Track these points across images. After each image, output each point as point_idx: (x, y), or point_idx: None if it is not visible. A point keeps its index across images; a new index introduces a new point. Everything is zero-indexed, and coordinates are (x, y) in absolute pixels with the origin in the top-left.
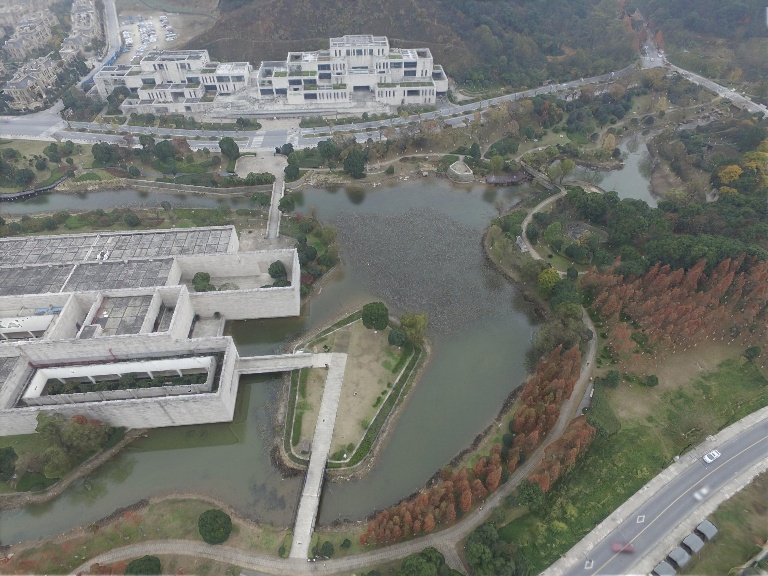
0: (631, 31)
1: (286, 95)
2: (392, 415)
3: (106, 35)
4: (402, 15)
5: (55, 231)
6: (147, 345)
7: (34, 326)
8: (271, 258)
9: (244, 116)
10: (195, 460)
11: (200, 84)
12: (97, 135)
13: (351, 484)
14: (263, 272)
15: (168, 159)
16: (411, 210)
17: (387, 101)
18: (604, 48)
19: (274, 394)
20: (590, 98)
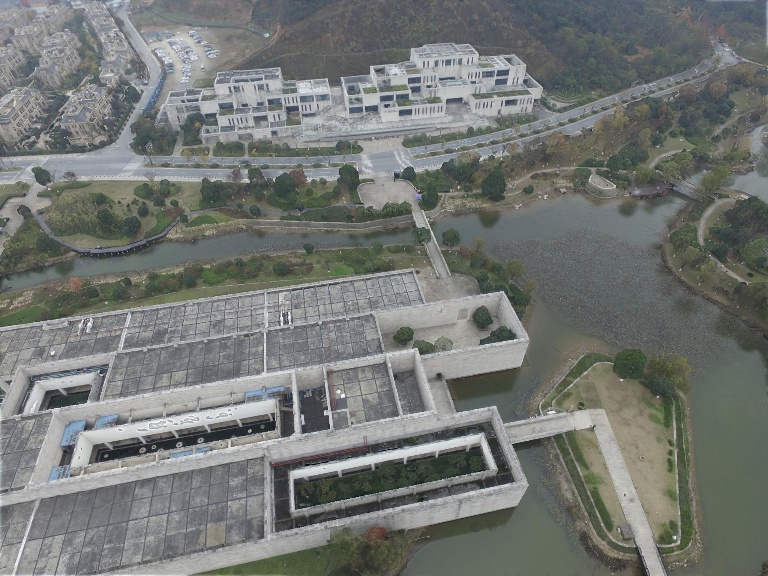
0: (695, 26)
1: (376, 112)
2: (689, 478)
3: (139, 55)
4: (476, 20)
5: (196, 288)
6: (406, 427)
7: (246, 413)
8: (475, 304)
9: (339, 138)
10: (484, 557)
11: (282, 106)
12: (184, 170)
13: (690, 570)
14: (457, 319)
15: (290, 194)
16: (571, 233)
17: (483, 113)
18: (680, 45)
19: (544, 466)
20: (693, 98)
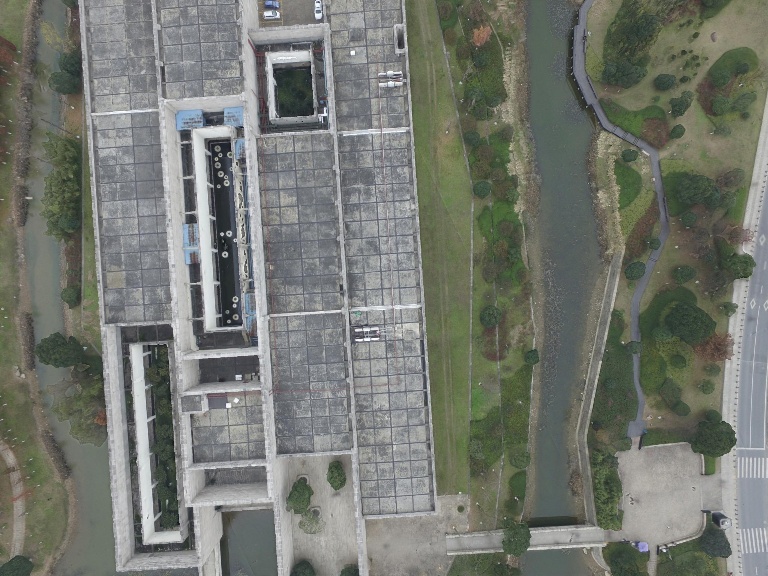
0: None
1: None
2: None
3: None
4: None
5: (472, 198)
6: None
7: None
8: None
9: None
10: None
11: None
12: None
13: None
14: (368, 544)
15: (666, 332)
16: None
17: None
18: None
19: None
20: None
